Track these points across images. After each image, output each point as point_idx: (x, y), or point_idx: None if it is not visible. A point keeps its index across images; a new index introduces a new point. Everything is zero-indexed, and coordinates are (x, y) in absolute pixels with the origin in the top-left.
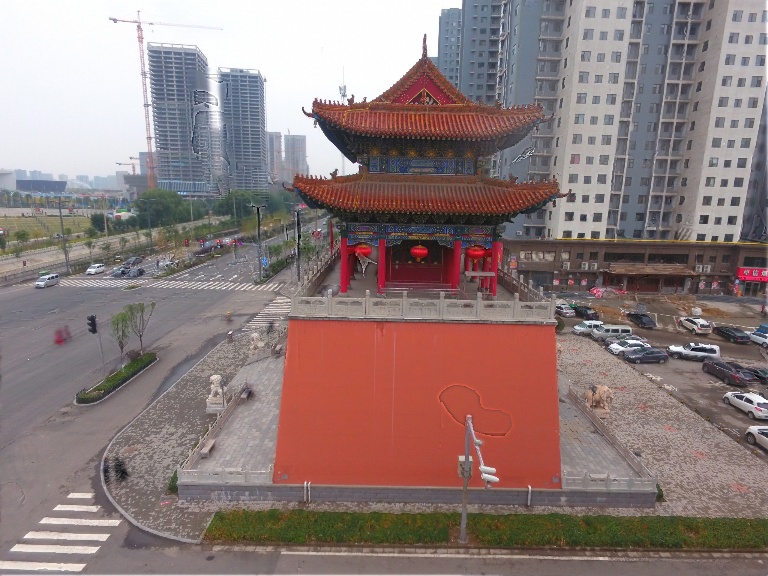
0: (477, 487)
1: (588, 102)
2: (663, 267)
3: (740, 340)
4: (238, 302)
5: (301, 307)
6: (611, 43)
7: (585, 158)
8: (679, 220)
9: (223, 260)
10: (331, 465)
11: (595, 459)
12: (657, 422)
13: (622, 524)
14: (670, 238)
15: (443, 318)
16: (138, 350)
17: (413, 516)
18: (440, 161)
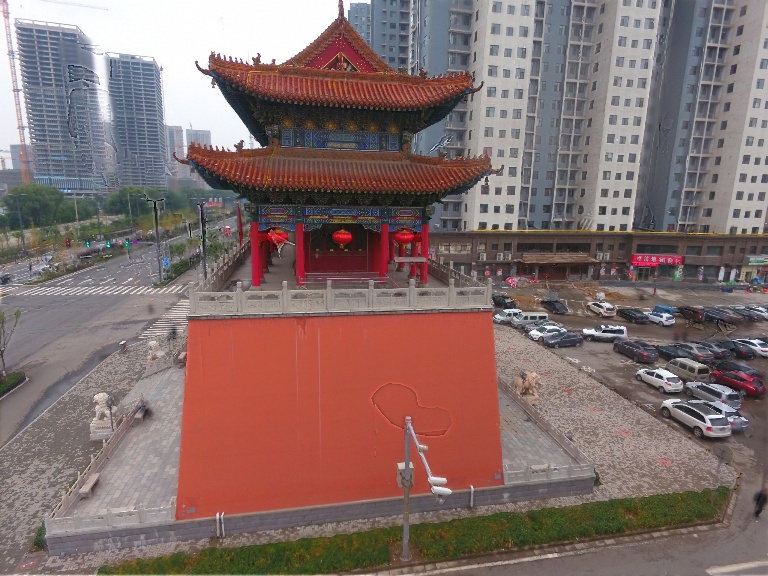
0: (417, 494)
1: (497, 96)
2: (569, 256)
3: (640, 320)
4: (134, 307)
5: (203, 304)
6: (516, 39)
7: (497, 151)
8: (581, 211)
9: (115, 261)
10: (249, 489)
11: (532, 449)
12: (582, 404)
13: (566, 515)
14: (574, 229)
15: (373, 309)
16: (1, 370)
17: (348, 537)
18: (361, 135)
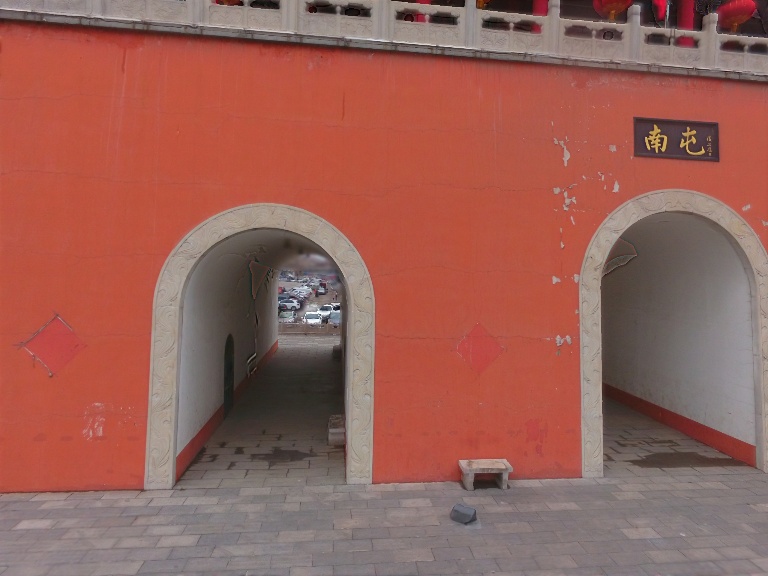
0: None
1: None
2: None
3: (286, 308)
4: None
5: None
6: None
7: None
8: None
9: None
10: None
11: None
12: None
13: None
14: None
15: None
16: None
17: None
18: None
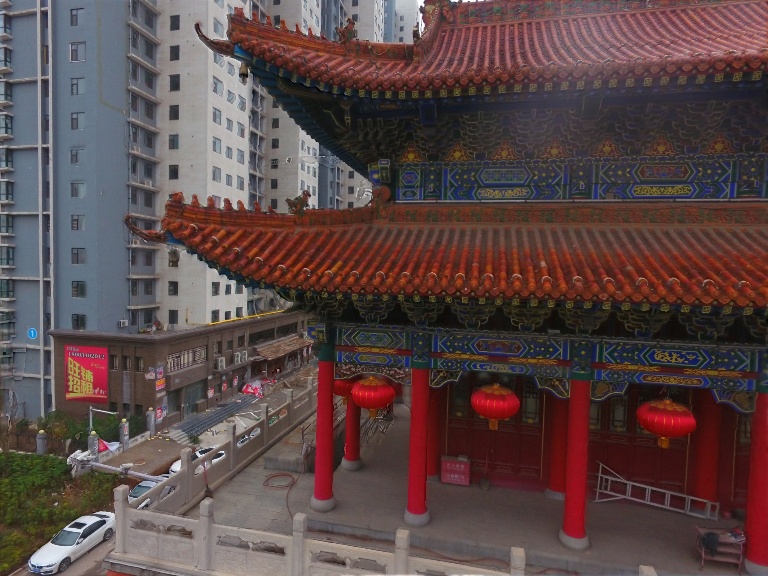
0: None
1: (223, 124)
2: (289, 340)
3: None
4: None
5: None
6: None
7: None
8: None
9: None
10: None
11: None
12: None
13: None
14: None
15: None
16: None
17: None
18: None
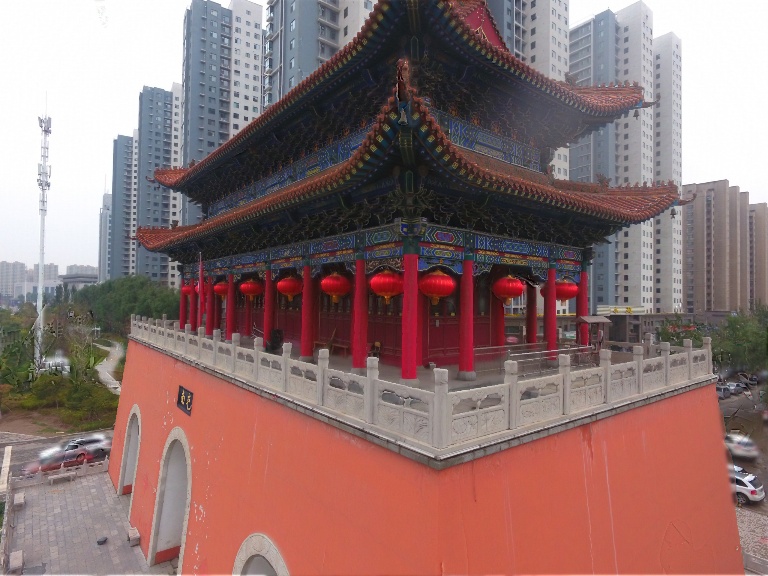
0: None
1: None
2: None
3: None
4: None
5: (459, 422)
6: None
7: None
8: None
9: None
10: None
11: None
12: None
13: None
14: None
15: (647, 395)
16: None
17: None
18: (508, 143)
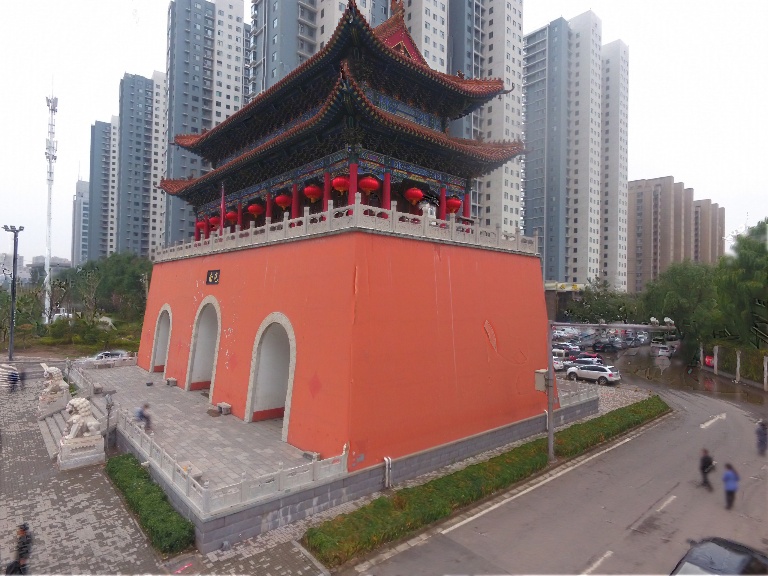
0: (517, 421)
1: None
2: None
3: None
4: None
5: (366, 218)
6: None
7: None
8: None
9: None
10: (406, 427)
11: None
12: None
13: None
14: None
15: (480, 244)
16: None
17: (503, 456)
18: (419, 112)
